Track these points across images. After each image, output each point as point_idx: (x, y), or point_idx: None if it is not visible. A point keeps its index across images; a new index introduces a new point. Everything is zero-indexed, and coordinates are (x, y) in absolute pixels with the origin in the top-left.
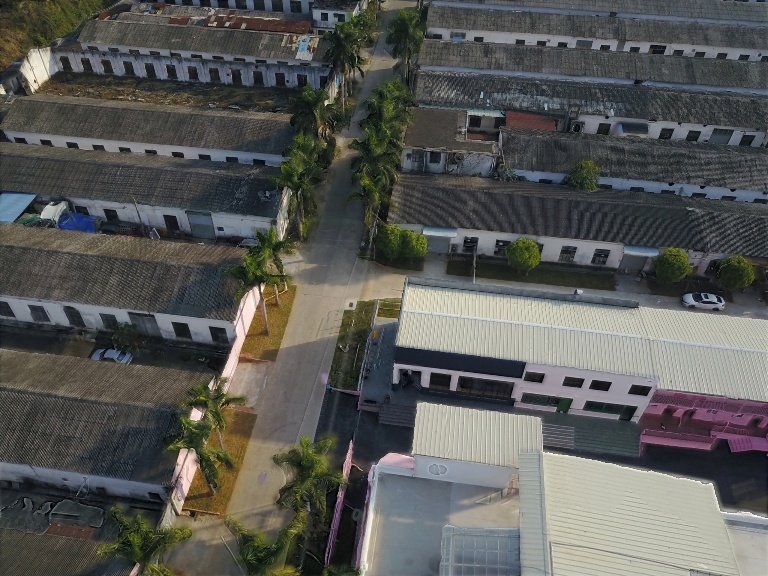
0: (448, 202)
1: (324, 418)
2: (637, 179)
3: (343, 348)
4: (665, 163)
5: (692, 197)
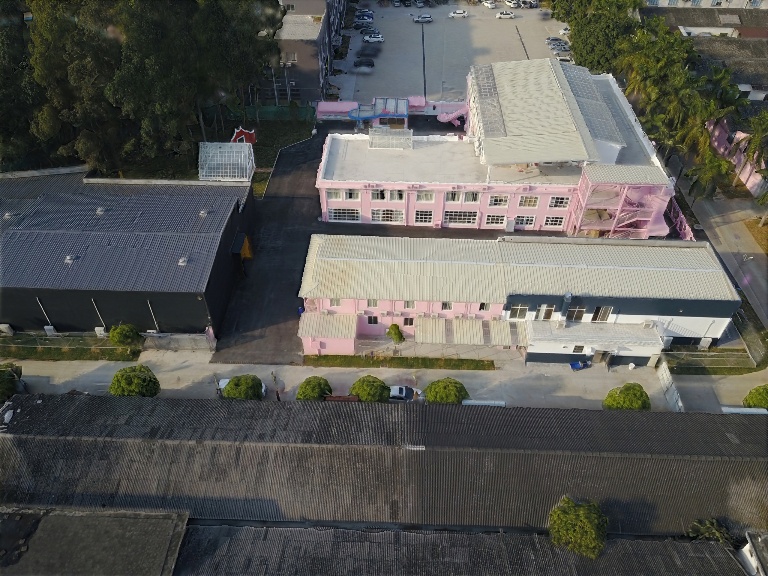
0: (767, 440)
1: (725, 270)
2: (486, 535)
3: (749, 257)
4: (436, 568)
5: (392, 519)
